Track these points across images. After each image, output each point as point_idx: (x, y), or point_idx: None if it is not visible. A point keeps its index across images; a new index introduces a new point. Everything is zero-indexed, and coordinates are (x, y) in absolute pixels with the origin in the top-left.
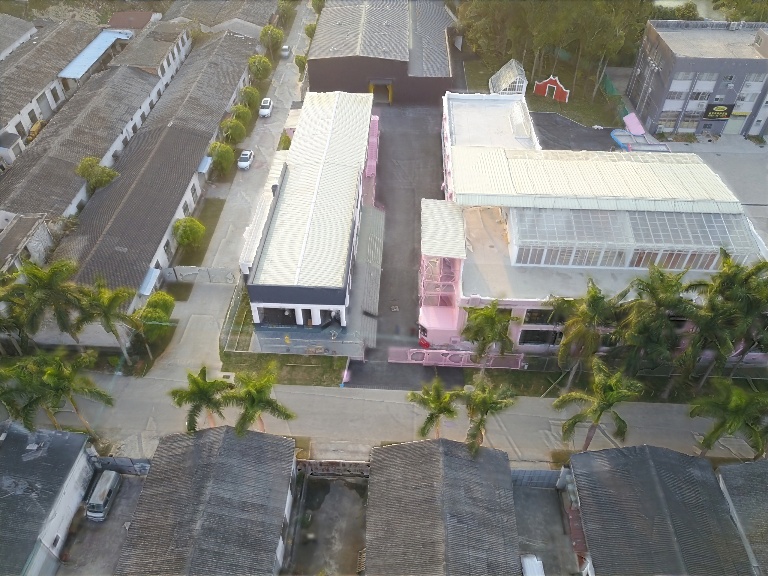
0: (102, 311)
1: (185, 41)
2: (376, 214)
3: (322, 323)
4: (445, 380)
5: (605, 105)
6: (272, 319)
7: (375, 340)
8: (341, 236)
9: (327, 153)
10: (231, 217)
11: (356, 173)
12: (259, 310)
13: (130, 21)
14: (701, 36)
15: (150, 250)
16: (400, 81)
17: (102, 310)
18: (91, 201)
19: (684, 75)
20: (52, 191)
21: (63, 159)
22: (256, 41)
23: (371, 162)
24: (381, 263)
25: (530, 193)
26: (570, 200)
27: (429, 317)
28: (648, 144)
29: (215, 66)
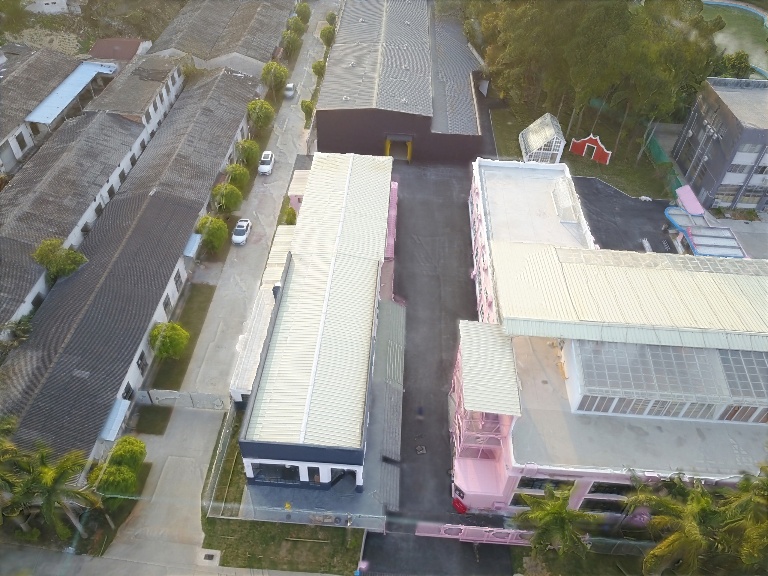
0: (45, 489)
1: (176, 79)
2: (396, 312)
3: (332, 478)
4: (488, 566)
5: (651, 169)
6: (269, 473)
7: (398, 499)
8: (358, 363)
9: (340, 240)
10: (222, 311)
11: (375, 268)
12: (253, 465)
13: (115, 50)
14: (765, 98)
15: (118, 373)
16: (421, 137)
17: (45, 489)
18: (50, 296)
19: (750, 147)
20: (1, 285)
21: (19, 240)
22: (257, 81)
23: (389, 239)
24: (403, 381)
25: (596, 320)
26: (646, 332)
27: (467, 475)
28: (709, 227)
29: (209, 113)
